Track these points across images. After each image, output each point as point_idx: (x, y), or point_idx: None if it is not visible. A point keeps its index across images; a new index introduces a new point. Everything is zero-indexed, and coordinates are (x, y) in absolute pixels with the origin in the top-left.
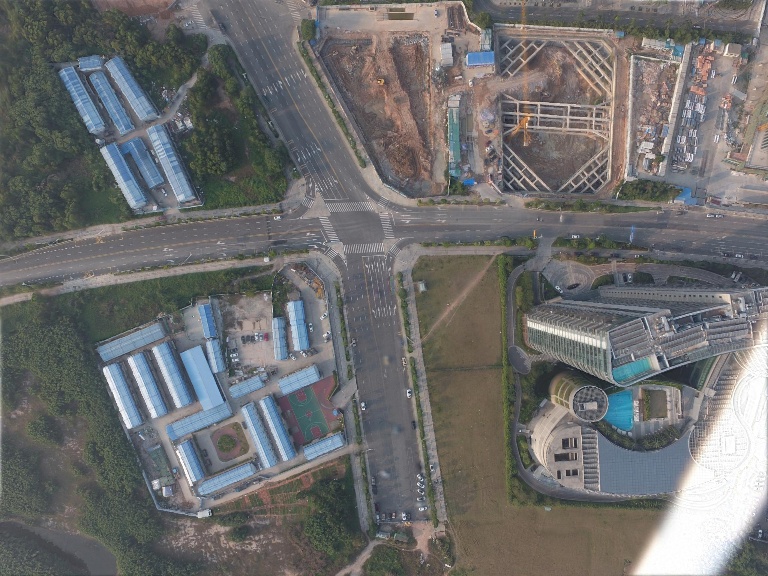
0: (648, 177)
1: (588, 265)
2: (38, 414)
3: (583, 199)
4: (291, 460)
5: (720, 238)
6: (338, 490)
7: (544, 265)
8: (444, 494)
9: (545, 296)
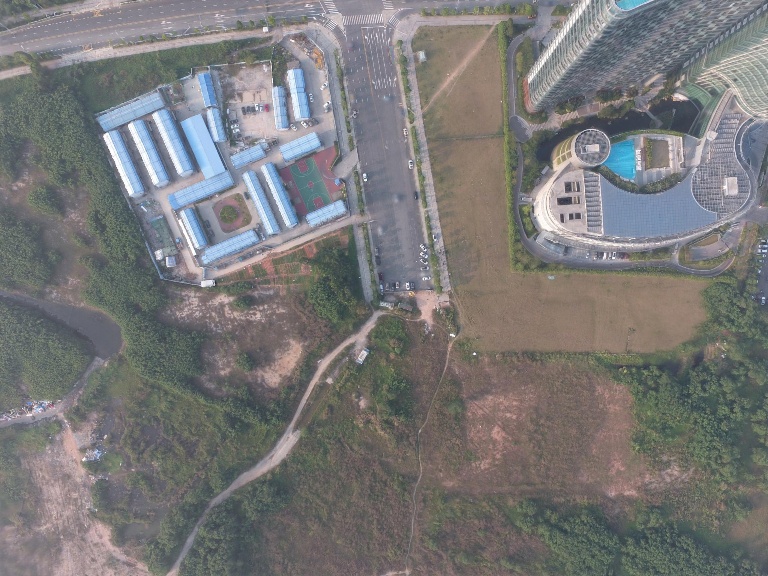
0: None
1: None
2: (39, 184)
3: None
4: (294, 231)
5: None
6: (341, 256)
7: (544, 34)
8: (447, 264)
9: None
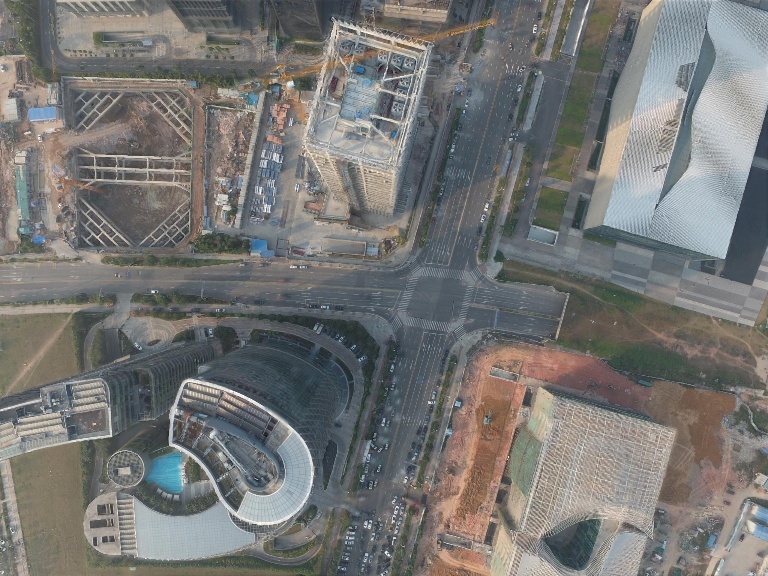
0: (227, 229)
1: (169, 320)
2: None
3: (159, 254)
4: None
5: (306, 289)
6: None
7: (123, 322)
8: (27, 556)
9: (124, 353)
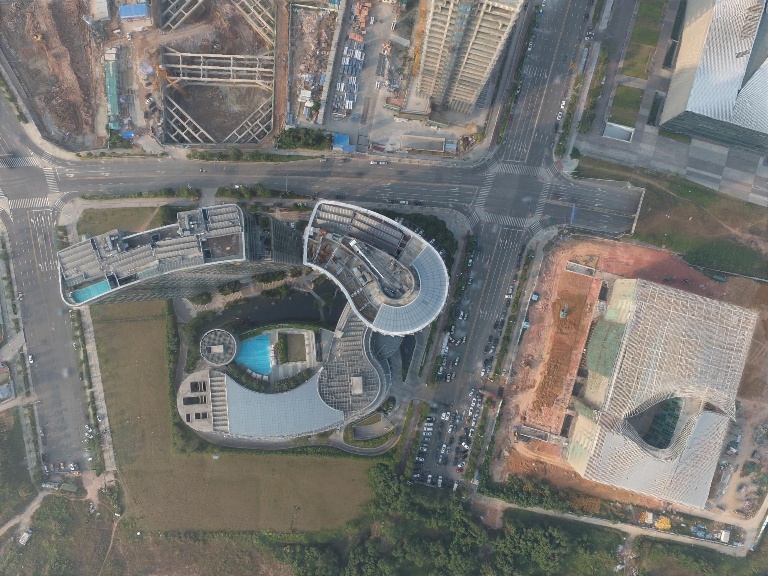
0: (309, 125)
1: None
2: None
3: (243, 149)
4: None
5: (385, 185)
6: (0, 441)
7: None
8: (113, 444)
9: None
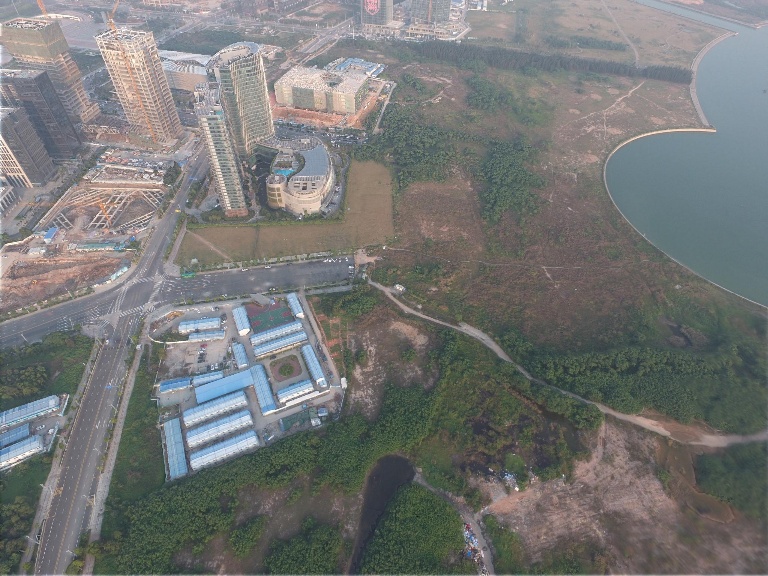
0: None
1: (207, 196)
2: (226, 543)
3: None
4: (306, 328)
5: None
6: None
7: (201, 212)
8: None
9: None
